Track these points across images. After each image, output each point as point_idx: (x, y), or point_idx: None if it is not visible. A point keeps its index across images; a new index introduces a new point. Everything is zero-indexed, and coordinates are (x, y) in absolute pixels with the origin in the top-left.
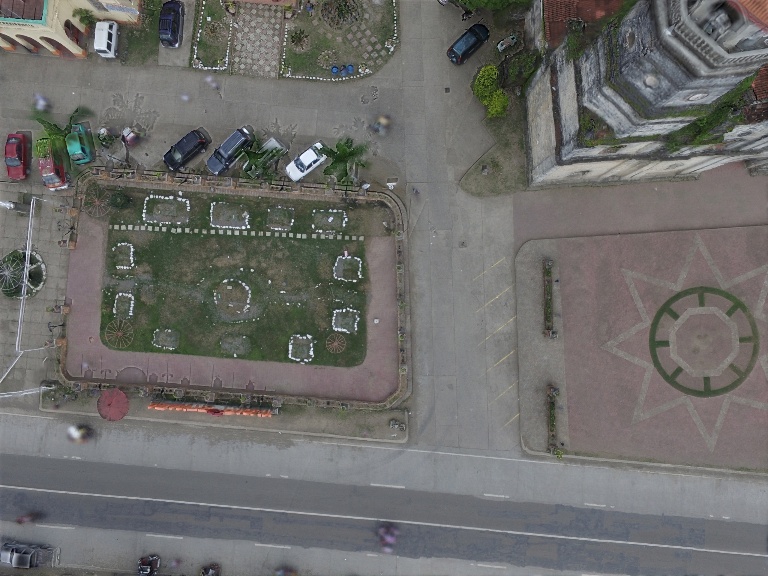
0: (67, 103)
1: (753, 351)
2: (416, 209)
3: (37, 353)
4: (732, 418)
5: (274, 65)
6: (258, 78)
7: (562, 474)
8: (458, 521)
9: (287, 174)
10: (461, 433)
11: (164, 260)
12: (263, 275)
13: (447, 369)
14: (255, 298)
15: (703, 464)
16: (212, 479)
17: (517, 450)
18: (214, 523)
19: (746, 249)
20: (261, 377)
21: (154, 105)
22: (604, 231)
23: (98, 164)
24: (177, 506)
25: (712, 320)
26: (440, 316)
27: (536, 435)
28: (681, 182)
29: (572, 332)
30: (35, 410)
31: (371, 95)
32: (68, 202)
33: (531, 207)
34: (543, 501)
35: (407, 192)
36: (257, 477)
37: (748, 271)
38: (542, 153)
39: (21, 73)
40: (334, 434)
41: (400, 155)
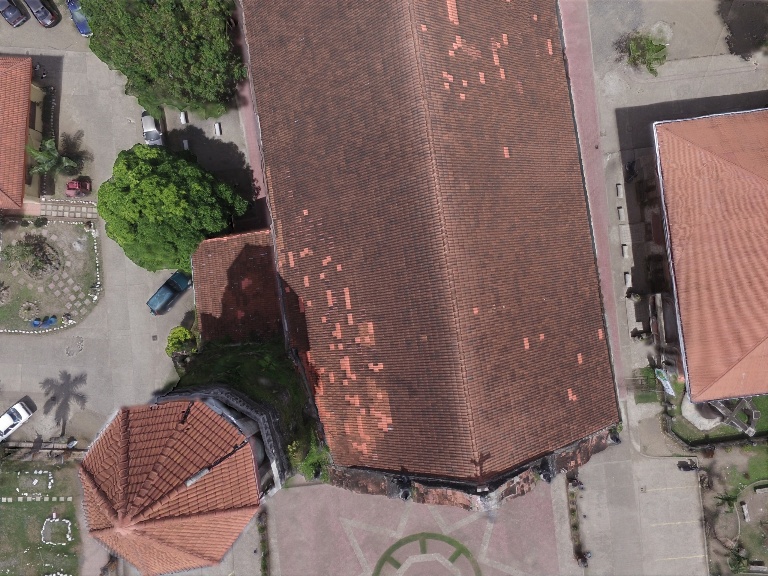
0: None
1: None
2: None
3: None
4: None
5: None
6: None
7: None
8: None
9: None
10: None
11: None
12: None
13: None
14: None
15: None
16: None
17: None
18: None
19: None
20: None
21: None
22: None
23: None
24: None
25: (434, 567)
26: None
27: None
28: None
29: None
30: None
31: (76, 346)
32: None
33: None
34: None
35: None
36: None
37: (470, 514)
38: None
39: None
40: None
41: (109, 408)
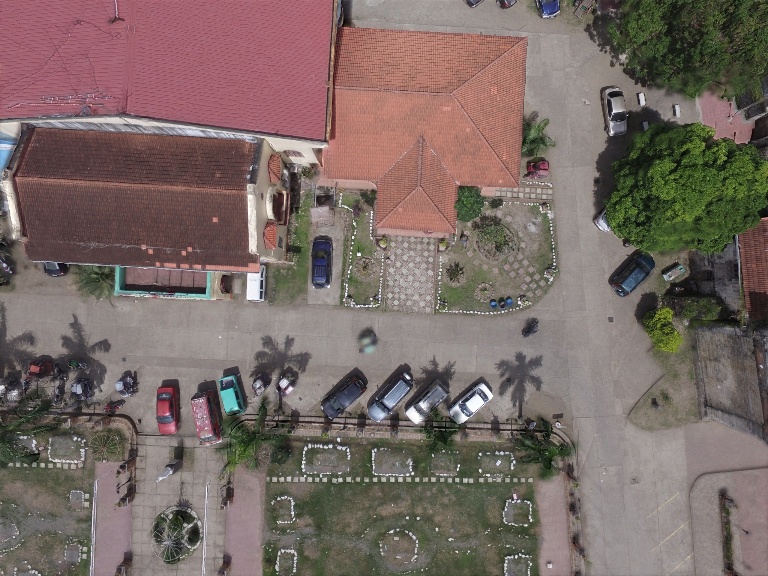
0: (214, 348)
1: None
2: (584, 445)
3: None
4: None
5: (429, 300)
6: (413, 314)
7: None
8: None
9: (450, 417)
10: None
11: (326, 511)
12: (429, 522)
13: None
14: (422, 547)
15: None
16: None
17: None
18: None
19: None
20: None
21: (305, 346)
22: None
23: (250, 411)
24: None
25: None
26: (614, 556)
27: None
28: None
29: (752, 568)
30: None
31: (531, 327)
32: (221, 454)
33: (703, 439)
34: None
35: (574, 428)
36: None
37: None
38: (728, 403)
39: (164, 318)
40: None
41: (565, 389)
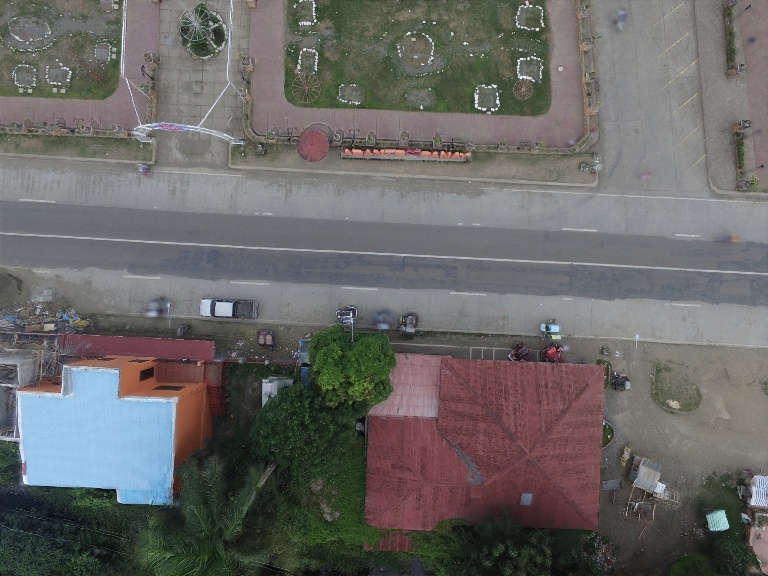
0: None
1: None
2: None
3: (222, 113)
4: None
5: None
6: None
7: (751, 212)
8: (651, 262)
9: None
10: (649, 176)
11: (346, 16)
12: (445, 27)
13: (632, 114)
14: (438, 51)
15: None
16: (404, 230)
17: (705, 190)
18: (409, 273)
19: None
20: (448, 129)
21: None
22: None
23: None
24: (371, 258)
25: None
26: (622, 62)
27: (724, 174)
28: None
29: (754, 72)
30: (223, 169)
31: None
32: None
33: None
34: (734, 239)
35: None
36: (449, 226)
37: None
38: None
39: None
40: (525, 180)
41: None
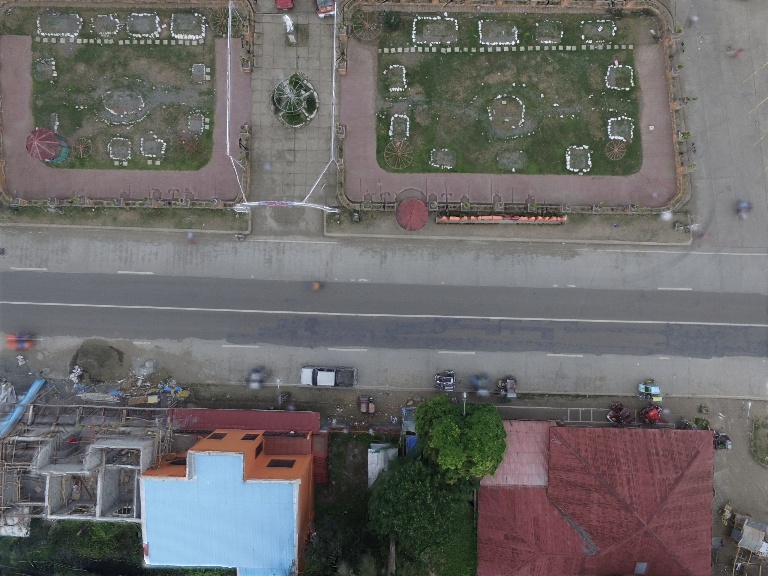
0: None
1: None
2: (681, 16)
3: (315, 180)
4: None
5: None
6: None
7: None
8: (747, 319)
9: None
10: (743, 233)
11: (435, 80)
12: (535, 89)
13: (724, 171)
14: (528, 113)
15: None
16: (499, 293)
17: None
18: (505, 336)
19: None
20: (540, 190)
21: None
22: None
23: None
24: (467, 322)
25: None
26: (713, 119)
27: None
28: None
29: None
30: (318, 236)
31: None
32: None
33: None
34: None
35: None
36: (544, 288)
37: None
38: None
39: None
40: (619, 240)
41: None
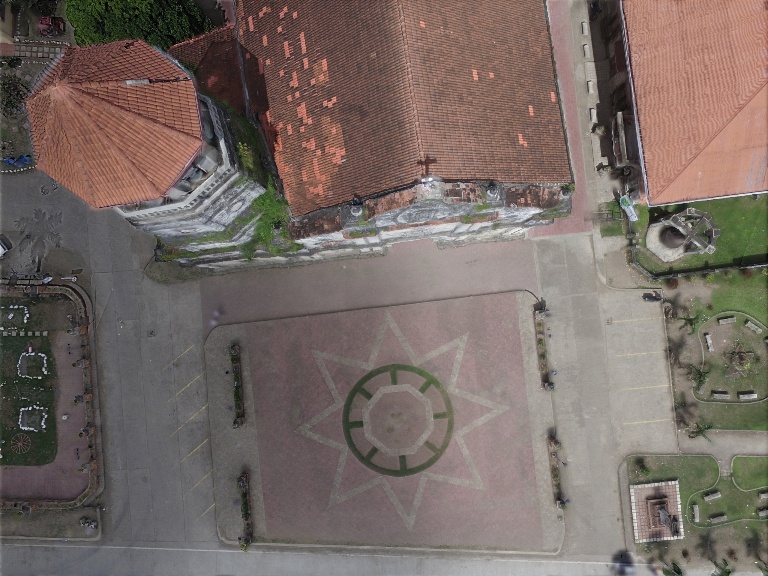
0: None
1: (448, 427)
2: (102, 300)
3: None
4: (429, 496)
5: None
6: None
7: (260, 562)
8: None
9: None
10: (157, 526)
11: None
12: None
13: (140, 462)
14: None
15: (402, 544)
16: None
17: (214, 540)
18: None
19: (437, 324)
20: None
21: None
22: (293, 313)
23: None
24: None
25: (405, 398)
26: (131, 408)
27: (232, 524)
28: (369, 259)
29: (264, 417)
30: None
31: (51, 185)
32: None
33: (219, 292)
34: None
35: (92, 283)
36: None
37: (440, 346)
38: None
39: None
40: (24, 536)
41: (84, 245)
